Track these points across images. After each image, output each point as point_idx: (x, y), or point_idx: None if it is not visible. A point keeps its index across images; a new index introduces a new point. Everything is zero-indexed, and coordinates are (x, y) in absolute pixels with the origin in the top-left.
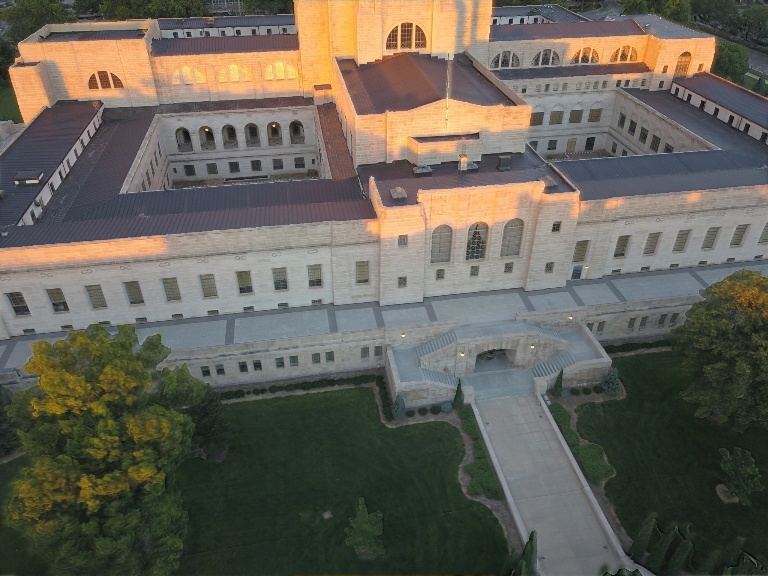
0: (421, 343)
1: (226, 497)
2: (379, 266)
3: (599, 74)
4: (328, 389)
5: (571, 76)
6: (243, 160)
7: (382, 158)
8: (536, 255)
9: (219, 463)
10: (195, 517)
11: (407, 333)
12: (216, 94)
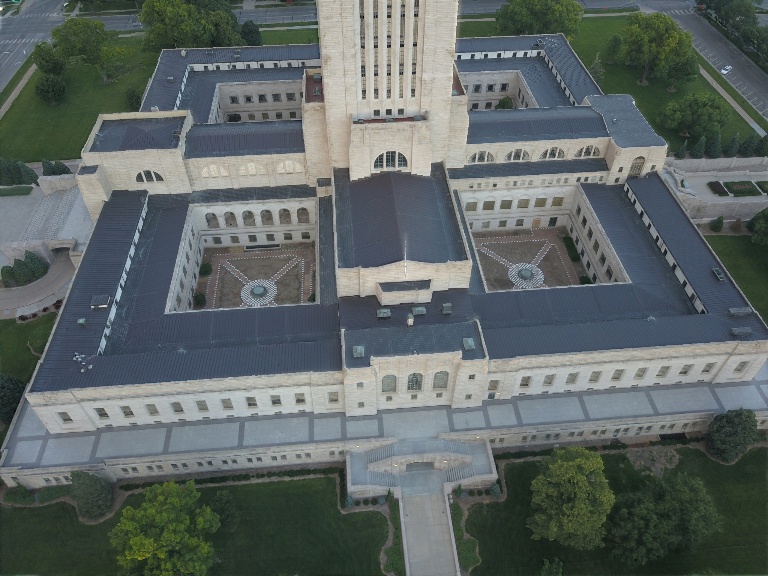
0: (371, 449)
1: (235, 559)
2: (344, 396)
3: (562, 171)
4: (306, 477)
5: (537, 173)
6: (260, 234)
7: (357, 293)
8: (458, 391)
9: (232, 533)
10: (217, 572)
11: (361, 445)
12: (238, 184)
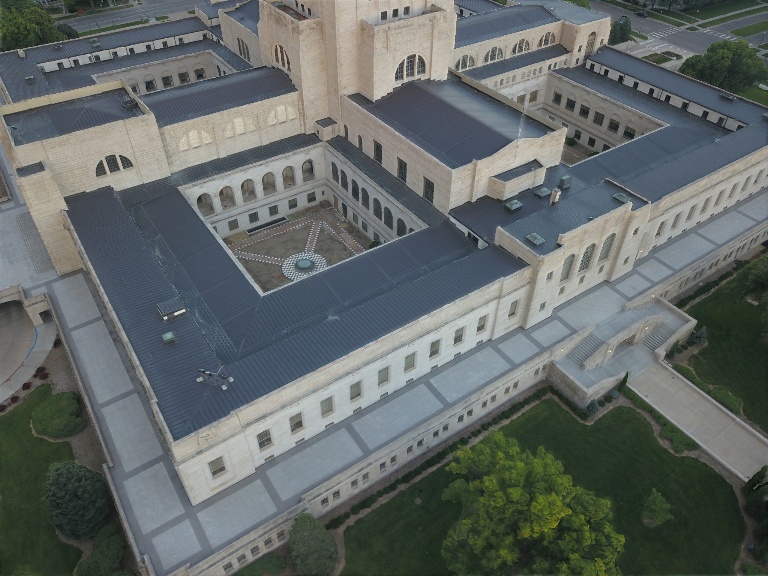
0: (570, 350)
1: None
2: (529, 300)
3: (535, 62)
4: (522, 411)
5: (517, 68)
6: (262, 209)
7: (467, 199)
8: (621, 255)
9: None
10: None
11: (565, 347)
12: (224, 150)
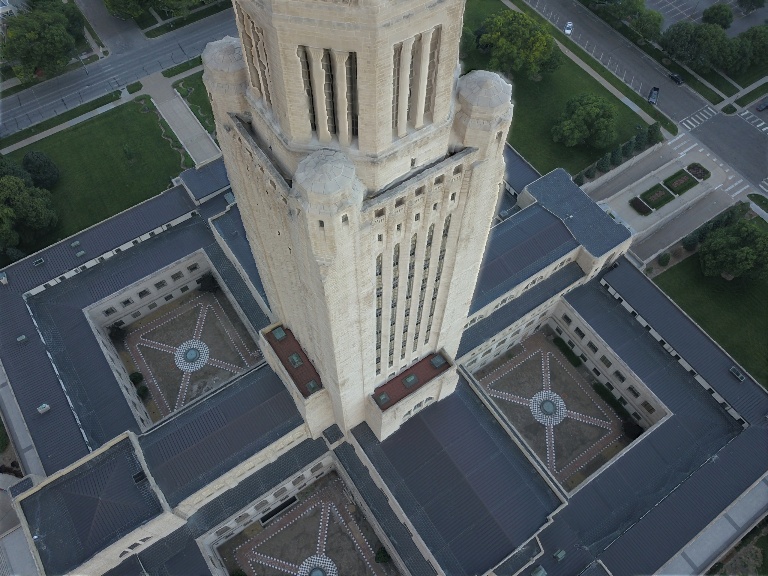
0: None
1: None
2: None
3: (547, 296)
4: None
5: (527, 310)
6: (274, 504)
7: None
8: None
9: None
10: None
11: None
12: (235, 483)
